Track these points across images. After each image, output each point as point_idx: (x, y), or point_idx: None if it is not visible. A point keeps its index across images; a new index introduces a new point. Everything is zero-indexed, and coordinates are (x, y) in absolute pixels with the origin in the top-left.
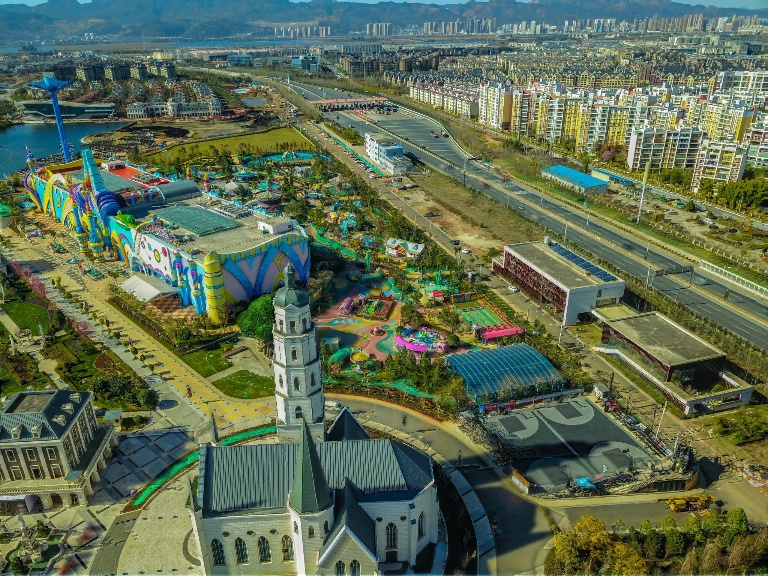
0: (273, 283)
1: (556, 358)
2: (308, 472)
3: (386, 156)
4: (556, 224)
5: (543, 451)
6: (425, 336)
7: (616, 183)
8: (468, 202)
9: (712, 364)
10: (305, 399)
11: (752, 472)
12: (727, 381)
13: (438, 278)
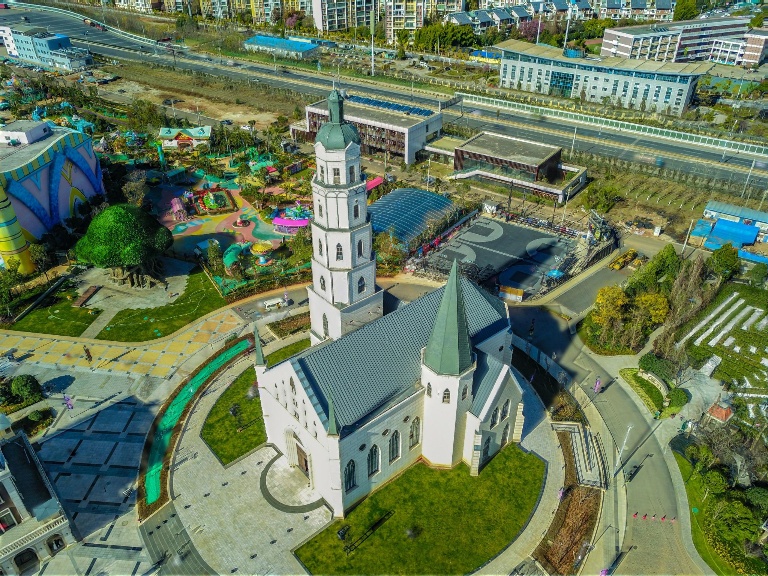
0: (69, 205)
1: (437, 191)
2: (462, 324)
3: (50, 50)
4: (305, 89)
5: (497, 266)
6: (300, 210)
7: (319, 46)
8: (197, 83)
9: (556, 158)
10: (368, 265)
11: (630, 227)
12: (567, 170)
13: (257, 155)
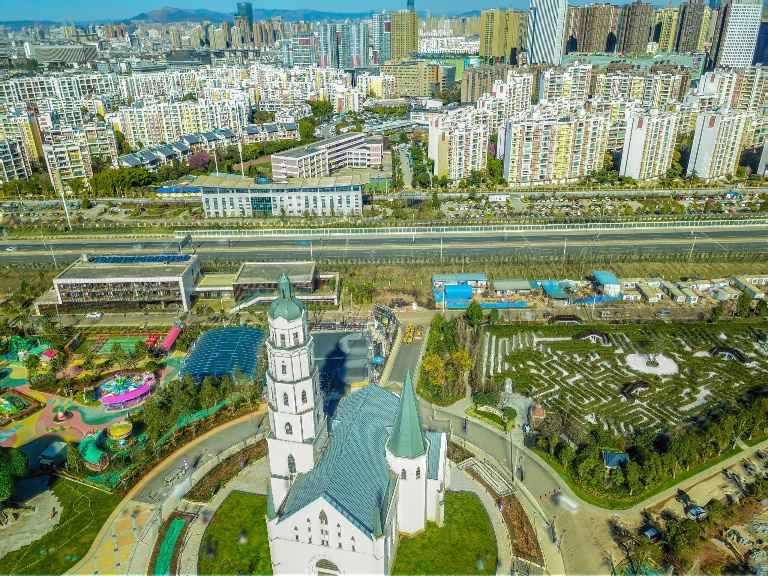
0: None
1: (239, 325)
2: None
3: None
4: (2, 259)
5: (331, 370)
6: (122, 382)
7: None
8: None
9: (315, 271)
10: (320, 400)
11: (394, 308)
12: (325, 278)
13: (24, 343)
